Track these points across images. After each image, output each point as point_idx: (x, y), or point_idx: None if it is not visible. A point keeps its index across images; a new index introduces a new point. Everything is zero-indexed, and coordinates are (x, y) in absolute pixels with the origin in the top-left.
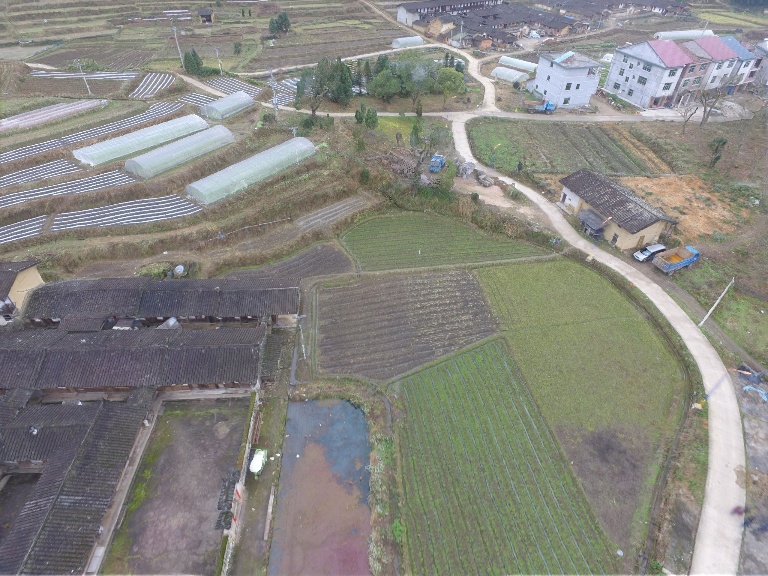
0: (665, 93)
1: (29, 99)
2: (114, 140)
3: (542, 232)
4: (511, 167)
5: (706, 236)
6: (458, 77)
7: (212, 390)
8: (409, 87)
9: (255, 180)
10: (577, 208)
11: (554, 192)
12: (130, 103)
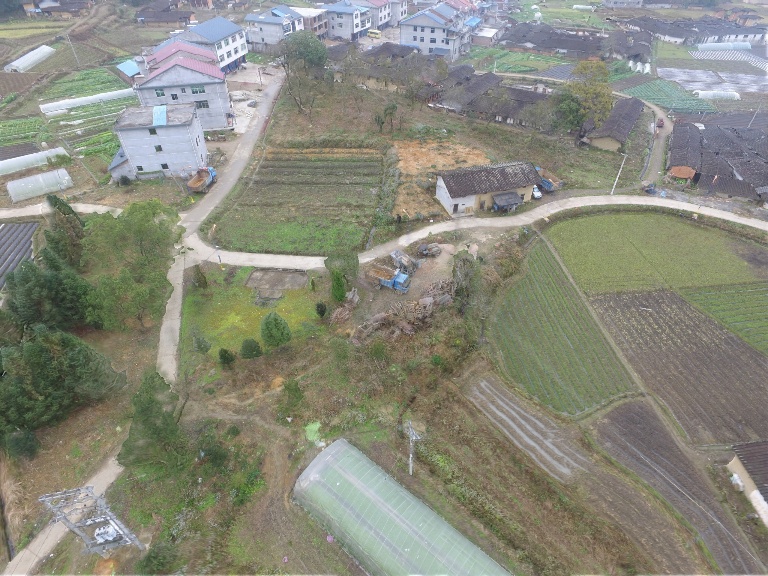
0: None
1: None
2: None
3: (520, 234)
4: (361, 233)
5: None
6: (161, 206)
7: None
8: (167, 264)
9: None
10: (475, 205)
11: None
12: None
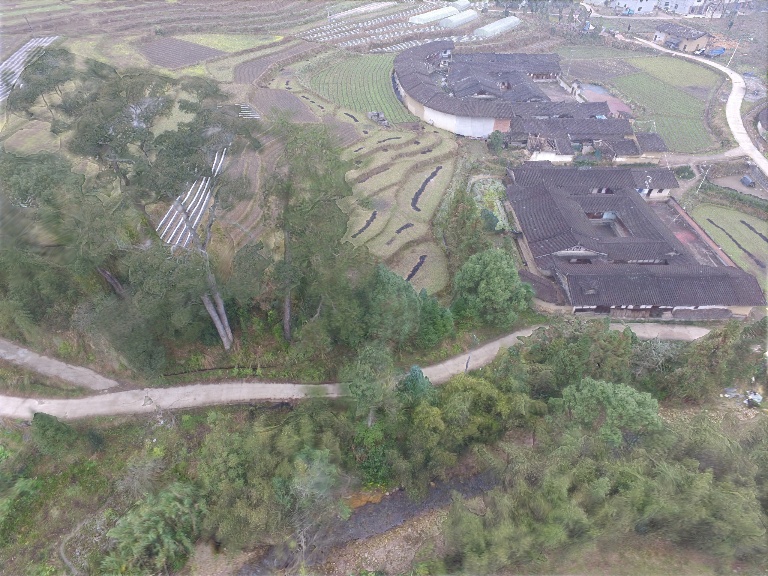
0: (698, 4)
1: (357, 1)
2: (427, 13)
3: (649, 47)
4: None
5: (727, 49)
6: None
7: (540, 80)
8: None
9: (502, 31)
10: (663, 40)
11: (649, 37)
12: (407, 4)
